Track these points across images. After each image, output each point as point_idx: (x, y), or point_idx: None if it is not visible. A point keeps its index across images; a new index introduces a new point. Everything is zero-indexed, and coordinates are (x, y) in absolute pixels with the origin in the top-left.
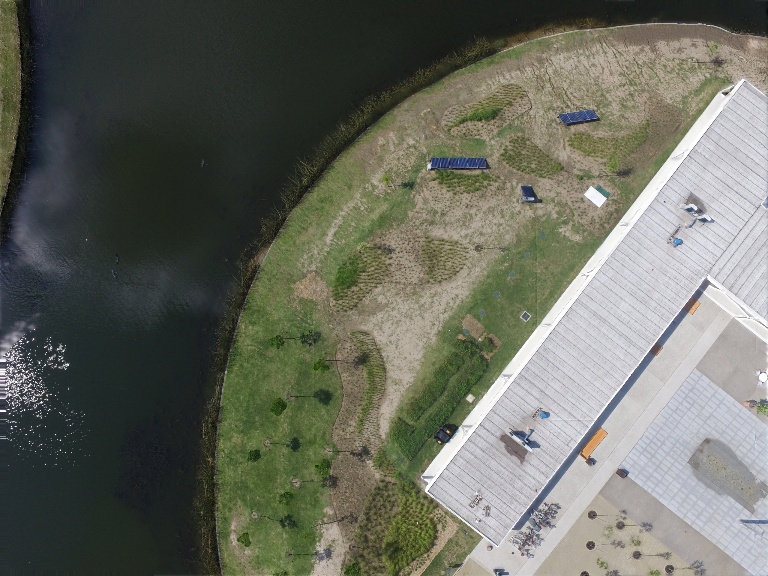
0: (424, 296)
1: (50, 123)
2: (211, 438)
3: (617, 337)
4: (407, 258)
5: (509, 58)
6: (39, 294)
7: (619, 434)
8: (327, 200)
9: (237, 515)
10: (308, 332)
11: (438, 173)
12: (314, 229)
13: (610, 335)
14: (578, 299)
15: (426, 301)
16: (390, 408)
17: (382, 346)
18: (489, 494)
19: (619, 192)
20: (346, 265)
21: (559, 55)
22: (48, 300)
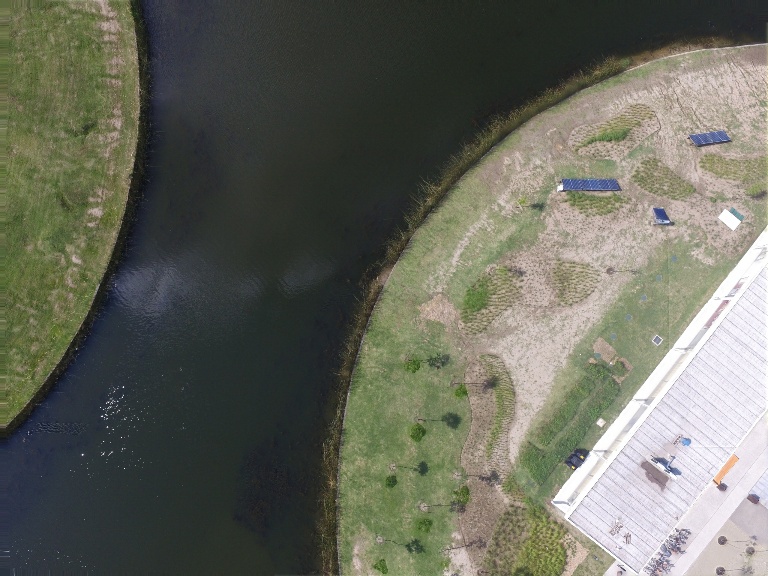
0: (554, 319)
1: (168, 140)
2: (332, 461)
3: (759, 363)
4: (538, 281)
5: (636, 77)
6: (156, 314)
7: (750, 459)
8: (452, 220)
9: (360, 539)
10: (436, 355)
11: (570, 195)
12: (439, 250)
13: (752, 361)
14: (720, 325)
15: (557, 324)
16: (520, 432)
17: (512, 369)
18: (629, 521)
19: (753, 215)
20: (475, 287)
21: (686, 74)
22: (165, 320)
